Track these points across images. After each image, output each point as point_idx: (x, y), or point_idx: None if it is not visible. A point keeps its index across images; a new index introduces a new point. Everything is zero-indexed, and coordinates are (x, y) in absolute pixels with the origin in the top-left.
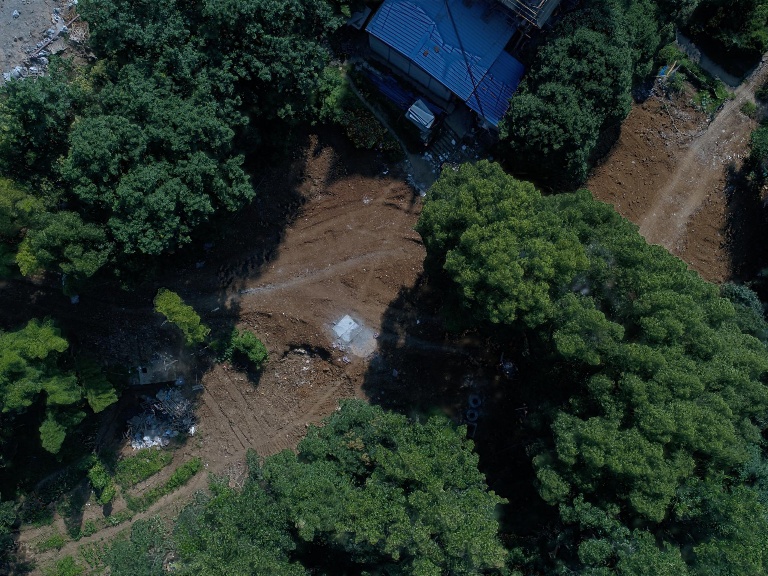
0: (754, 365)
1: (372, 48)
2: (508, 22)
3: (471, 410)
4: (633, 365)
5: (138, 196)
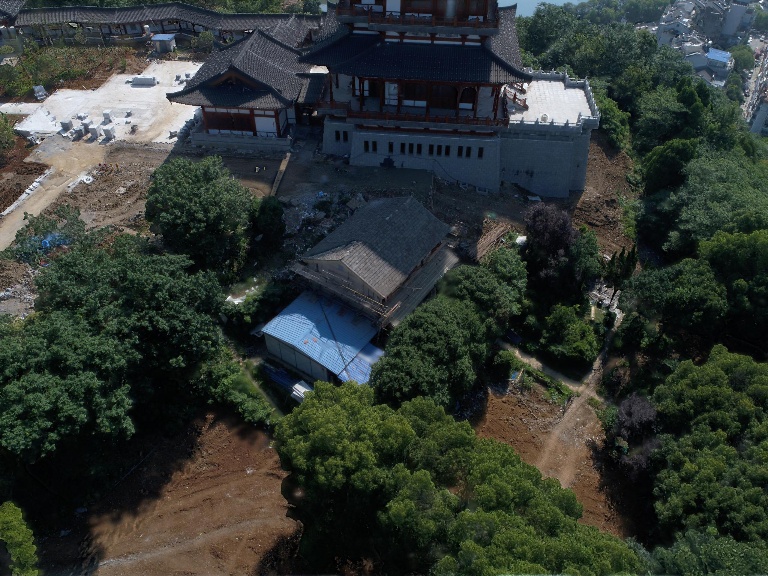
0: (611, 549)
1: (269, 351)
2: (370, 321)
3: None
4: (468, 529)
5: (20, 392)
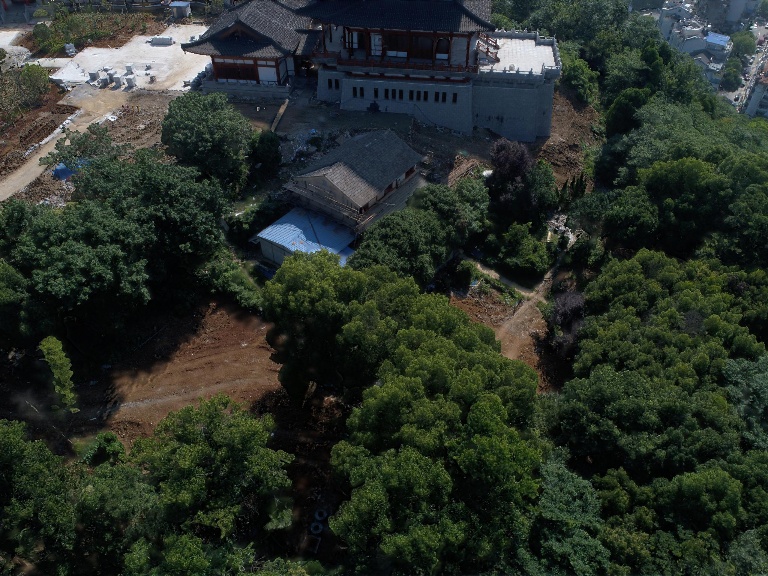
0: (515, 365)
1: (264, 255)
2: None
3: (316, 522)
4: (402, 340)
5: (61, 252)
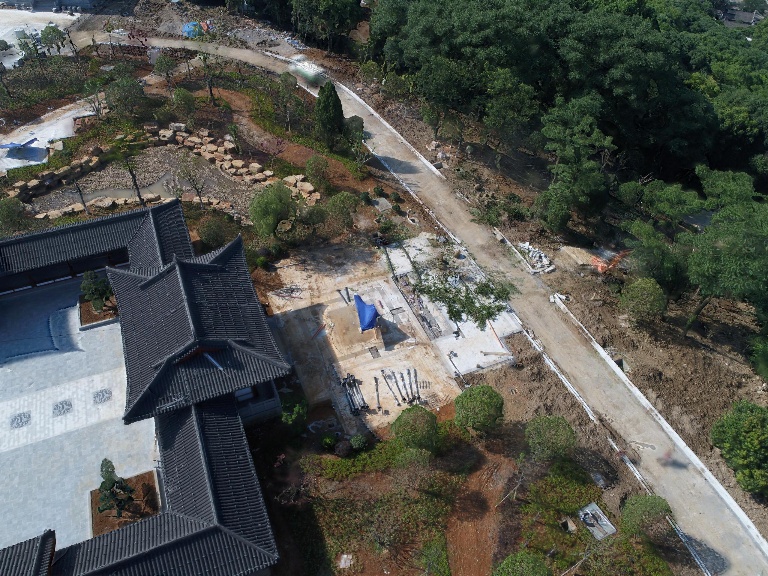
0: None
1: None
2: None
3: None
4: None
5: None
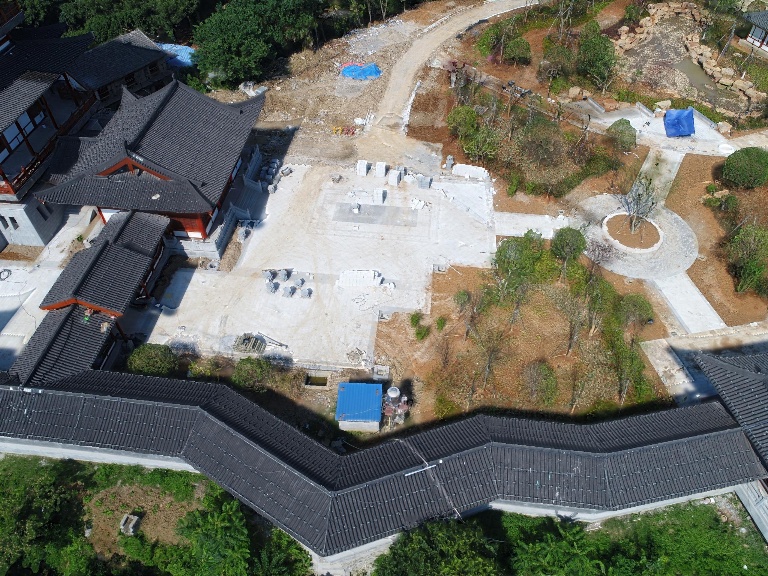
0: None
1: None
2: None
3: None
4: None
5: None
